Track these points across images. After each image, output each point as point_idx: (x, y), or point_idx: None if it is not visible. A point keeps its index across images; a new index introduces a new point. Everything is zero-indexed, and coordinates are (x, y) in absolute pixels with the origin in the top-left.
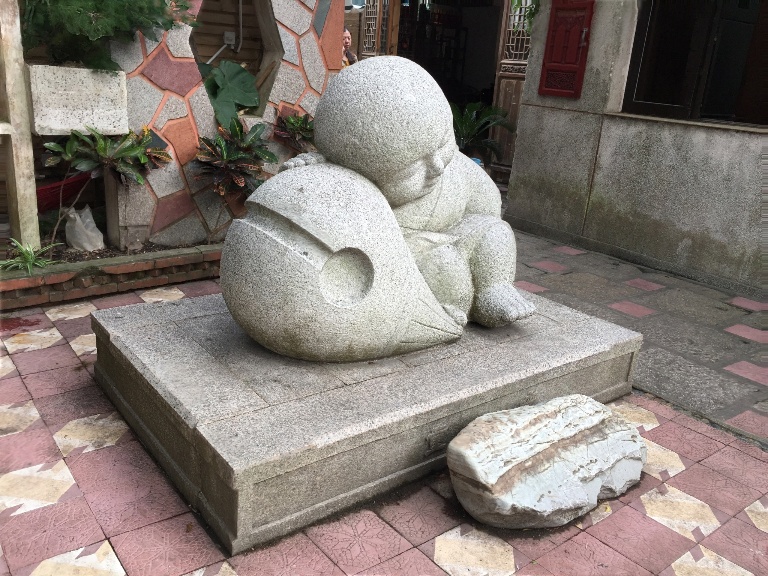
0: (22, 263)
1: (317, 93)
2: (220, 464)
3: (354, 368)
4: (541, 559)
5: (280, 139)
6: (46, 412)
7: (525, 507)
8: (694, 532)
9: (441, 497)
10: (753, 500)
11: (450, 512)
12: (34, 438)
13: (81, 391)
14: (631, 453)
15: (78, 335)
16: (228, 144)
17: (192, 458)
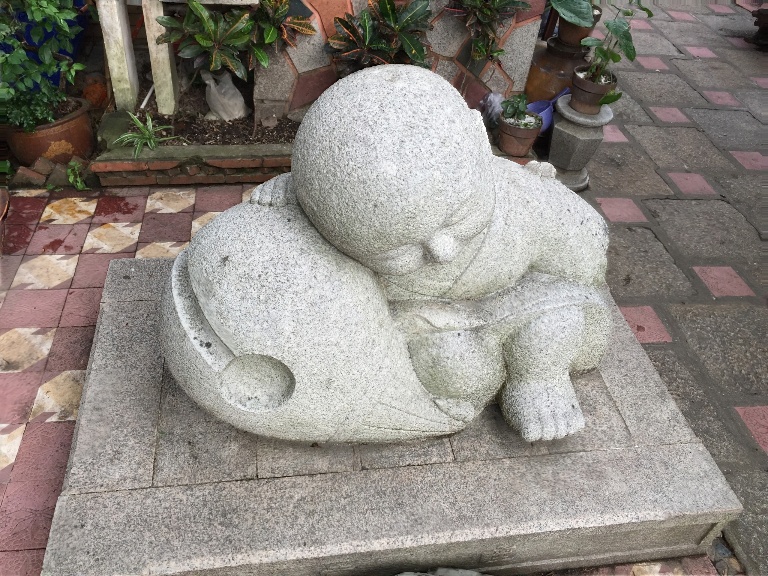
0: (138, 138)
1: None
2: None
3: (288, 449)
4: None
5: None
6: (56, 350)
7: None
8: None
9: None
10: None
11: None
12: (24, 385)
13: None
14: None
15: (151, 241)
16: (375, 25)
17: None
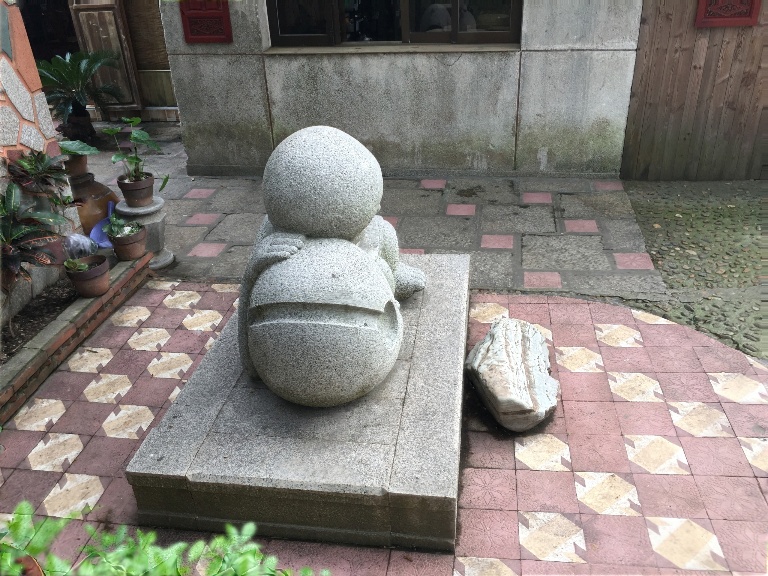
0: None
1: (31, 123)
2: (434, 502)
3: (386, 384)
4: (569, 430)
5: (19, 189)
6: None
7: (550, 408)
8: (598, 367)
9: (484, 432)
10: (594, 331)
11: (500, 437)
12: None
13: (153, 542)
14: (541, 340)
15: (40, 503)
16: None
17: (377, 515)
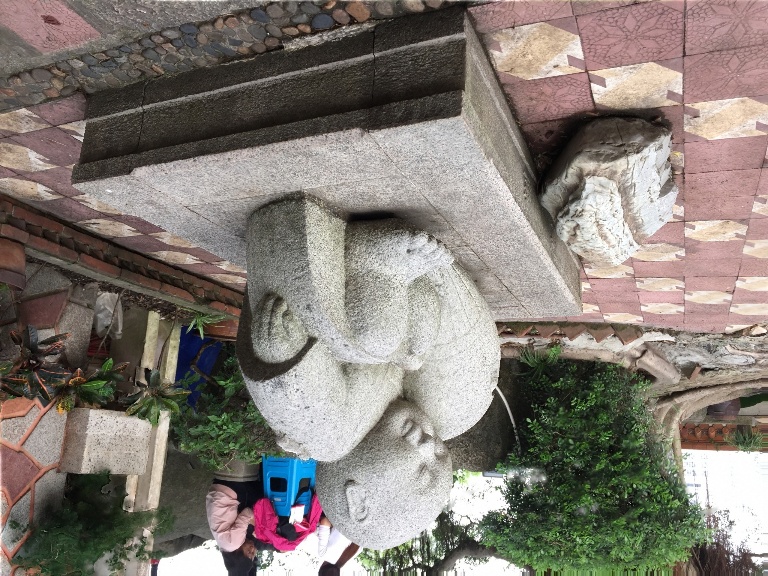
0: None
1: None
2: None
3: None
4: None
5: None
6: None
7: None
8: (759, 129)
9: None
10: None
11: None
12: None
13: None
14: None
15: None
16: None
17: None
